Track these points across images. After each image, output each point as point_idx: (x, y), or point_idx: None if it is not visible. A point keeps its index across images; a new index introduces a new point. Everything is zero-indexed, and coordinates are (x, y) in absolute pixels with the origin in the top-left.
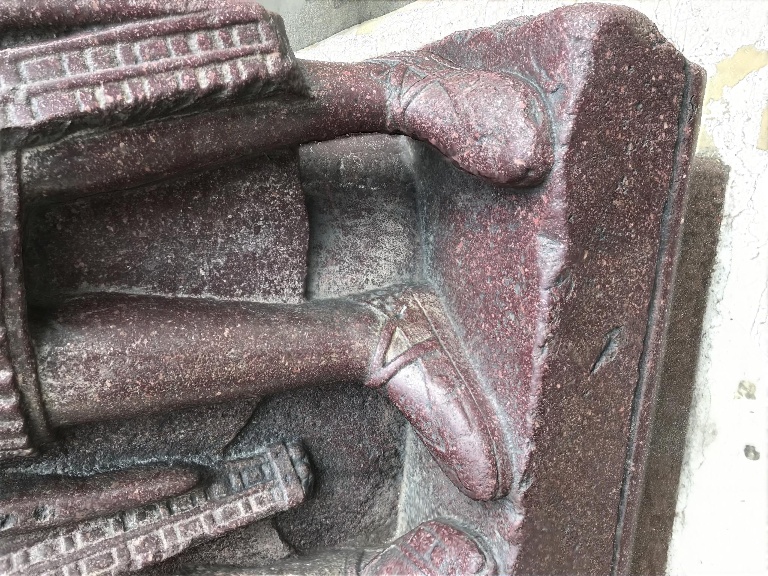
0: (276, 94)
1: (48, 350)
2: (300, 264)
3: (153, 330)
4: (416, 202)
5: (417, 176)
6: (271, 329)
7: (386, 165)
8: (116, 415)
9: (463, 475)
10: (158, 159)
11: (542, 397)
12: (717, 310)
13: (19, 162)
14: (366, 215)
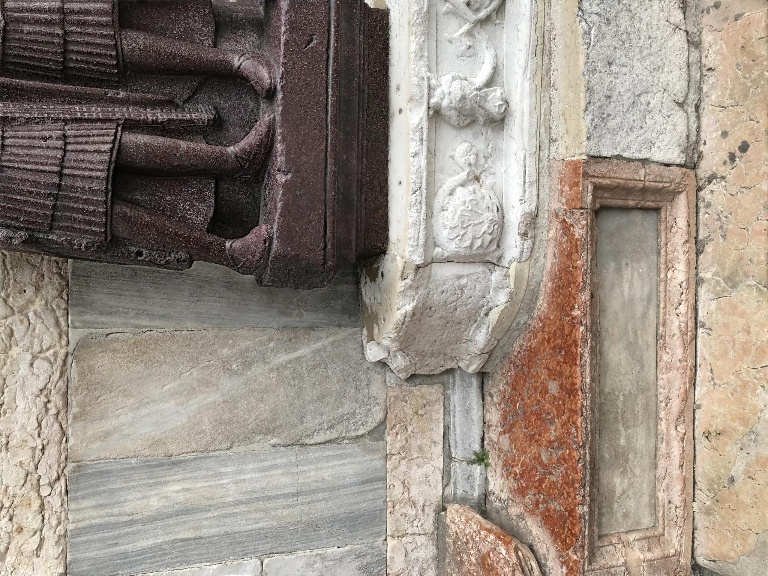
0: None
1: (124, 33)
2: (212, 36)
3: (157, 36)
4: (263, 28)
5: (264, 20)
6: (198, 45)
7: (252, 17)
8: (144, 62)
9: (261, 83)
10: None
11: (285, 52)
12: (391, 65)
13: None
14: (242, 30)
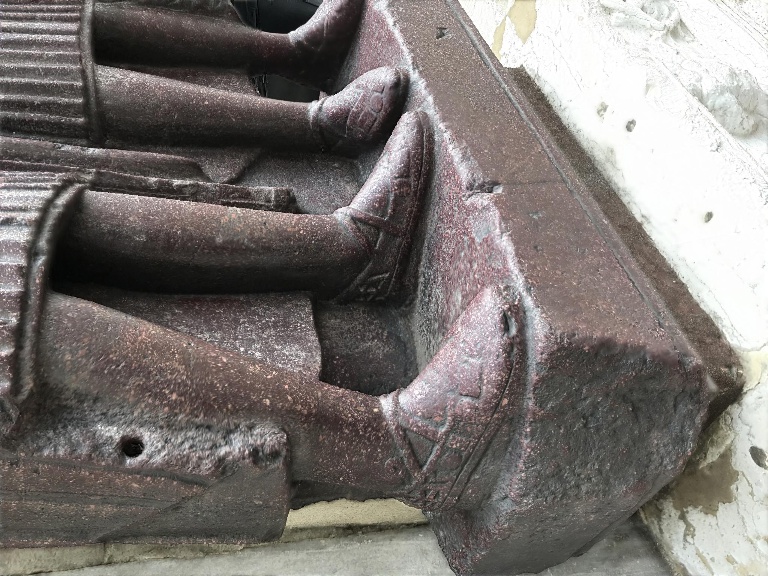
0: (223, 16)
1: None
2: None
3: None
4: None
5: None
6: None
7: None
8: (139, 104)
9: (376, 83)
10: (163, 23)
11: None
12: (563, 109)
13: (94, 3)
14: None
